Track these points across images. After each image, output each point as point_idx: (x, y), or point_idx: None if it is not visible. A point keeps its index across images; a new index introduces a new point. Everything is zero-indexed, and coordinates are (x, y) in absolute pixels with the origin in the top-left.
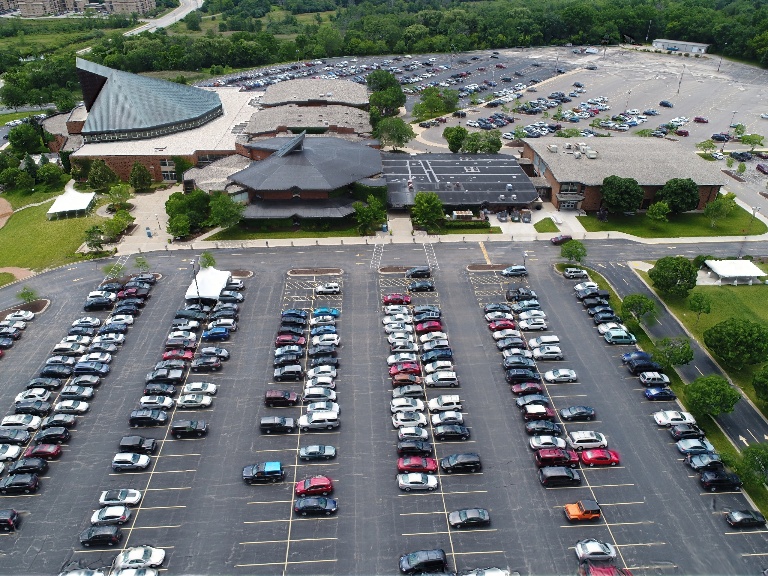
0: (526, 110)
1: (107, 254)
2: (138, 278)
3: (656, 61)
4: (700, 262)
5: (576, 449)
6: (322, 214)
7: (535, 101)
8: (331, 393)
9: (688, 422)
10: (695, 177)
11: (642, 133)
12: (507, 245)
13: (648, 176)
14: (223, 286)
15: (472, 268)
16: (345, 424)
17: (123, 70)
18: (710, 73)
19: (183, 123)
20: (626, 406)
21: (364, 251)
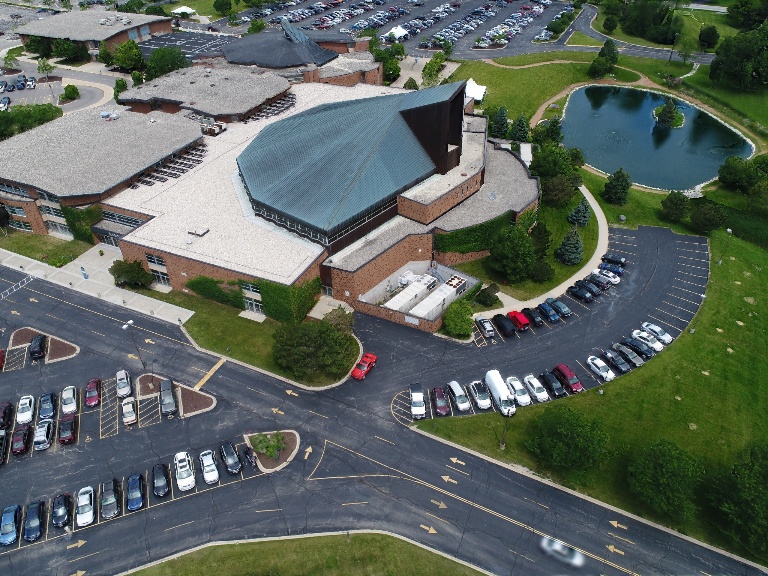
0: None
1: None
2: None
3: None
4: None
5: None
6: None
7: None
8: None
9: None
10: None
11: None
12: None
13: None
14: None
15: None
16: None
17: None
18: None
19: None
20: None
21: None
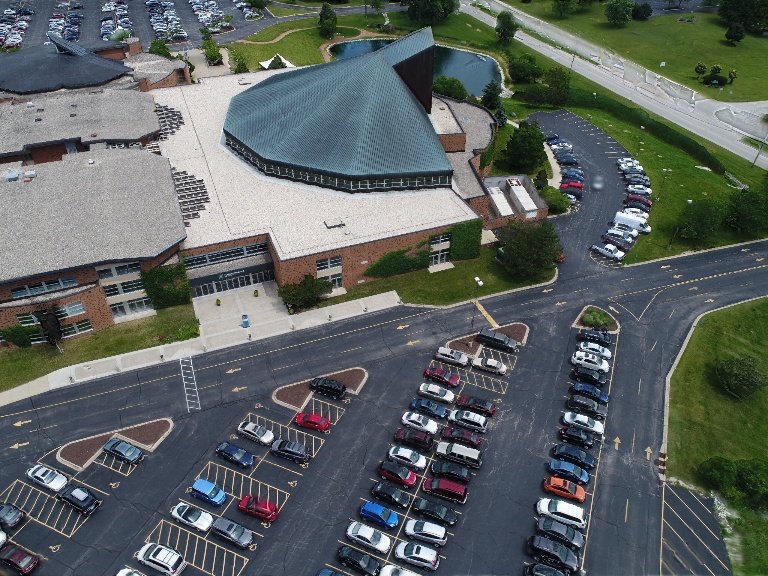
0: None
1: None
2: None
3: None
4: None
5: None
6: None
7: None
8: None
9: None
10: None
11: None
12: None
13: None
14: None
15: None
16: None
17: None
18: None
19: None
20: None
21: None
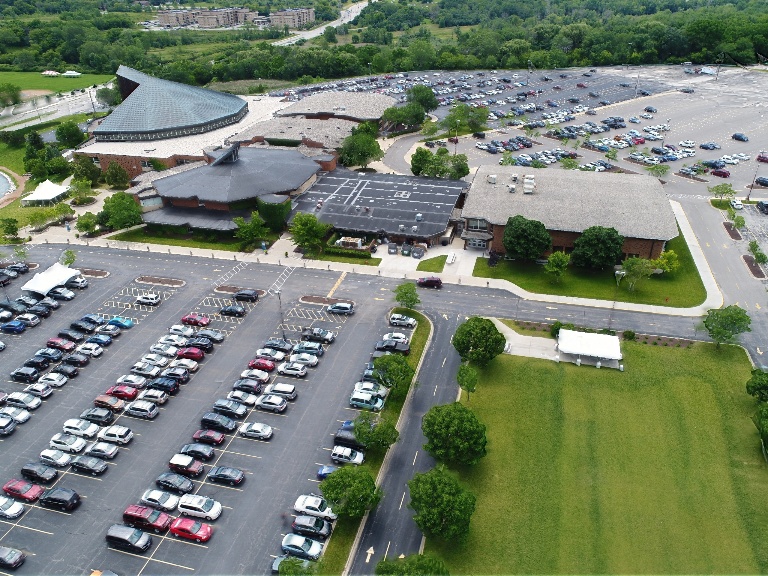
0: (558, 135)
1: (20, 241)
2: (11, 266)
3: None
4: (554, 330)
5: (181, 514)
6: (210, 225)
7: (577, 125)
8: (32, 401)
9: (325, 515)
10: (634, 227)
11: (653, 169)
12: (369, 279)
13: (574, 220)
14: (60, 283)
15: (304, 299)
16: (17, 434)
17: (225, 77)
18: None
19: (186, 128)
20: (287, 480)
21: (225, 267)
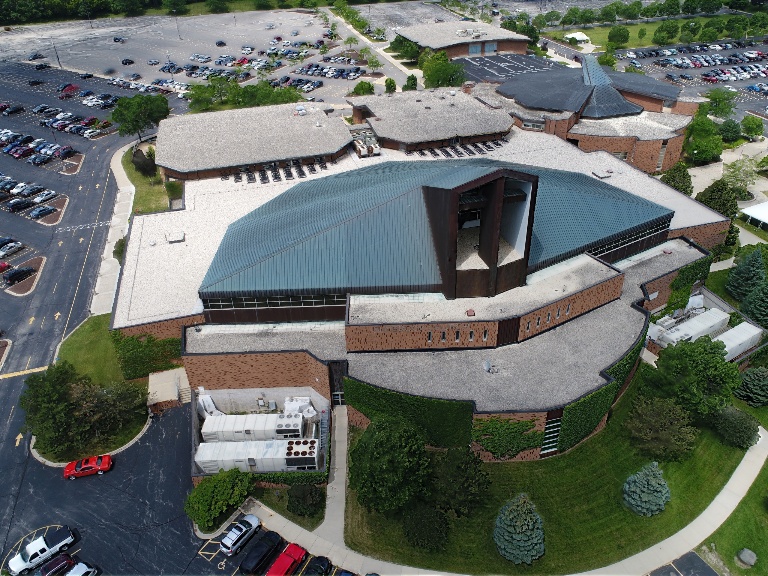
0: (242, 76)
1: None
2: None
3: (23, 39)
4: None
5: None
6: None
7: (210, 72)
8: None
9: None
10: None
11: None
12: None
13: None
14: None
15: None
16: None
17: None
18: (108, 29)
19: None
20: None
21: None
